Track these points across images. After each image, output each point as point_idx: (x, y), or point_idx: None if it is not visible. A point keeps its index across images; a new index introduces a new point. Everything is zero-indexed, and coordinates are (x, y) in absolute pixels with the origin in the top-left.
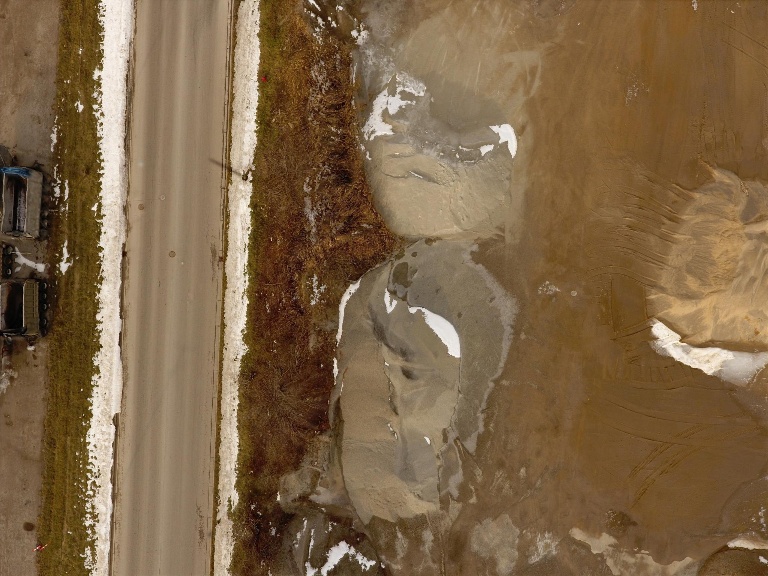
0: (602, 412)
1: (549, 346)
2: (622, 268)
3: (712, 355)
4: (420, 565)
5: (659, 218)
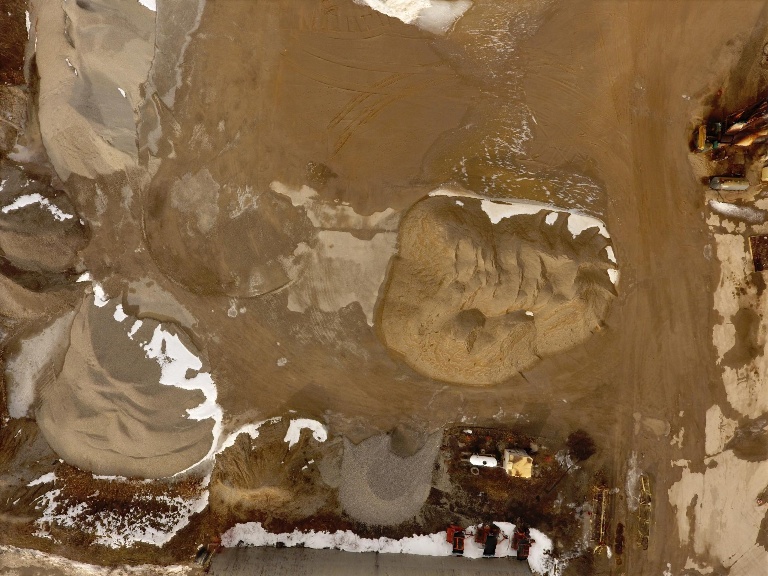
0: (300, 63)
1: None
2: None
3: (409, 3)
4: (120, 221)
5: None
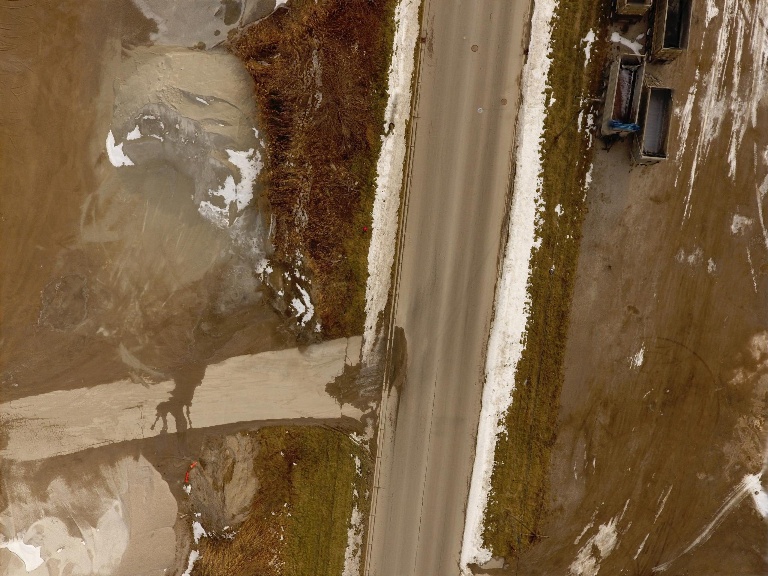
0: None
1: None
2: None
3: None
4: None
5: None
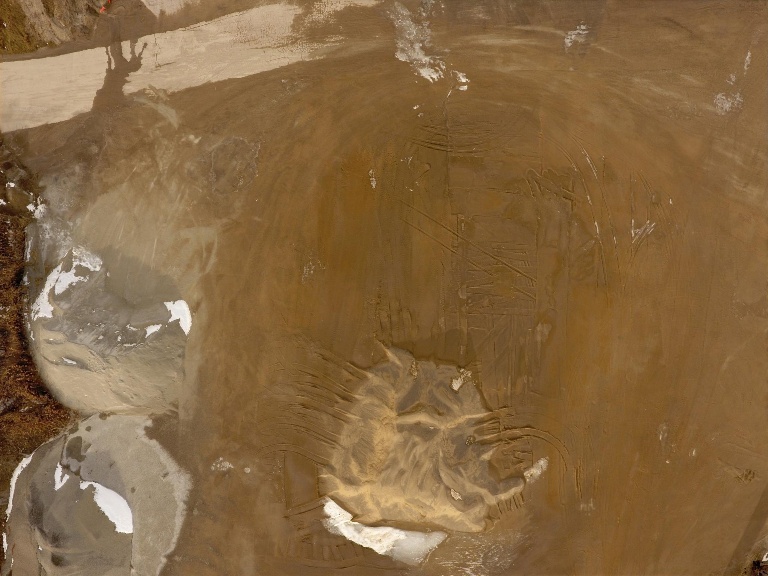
0: None
1: (221, 523)
2: (295, 446)
3: (384, 534)
4: None
5: (333, 396)
